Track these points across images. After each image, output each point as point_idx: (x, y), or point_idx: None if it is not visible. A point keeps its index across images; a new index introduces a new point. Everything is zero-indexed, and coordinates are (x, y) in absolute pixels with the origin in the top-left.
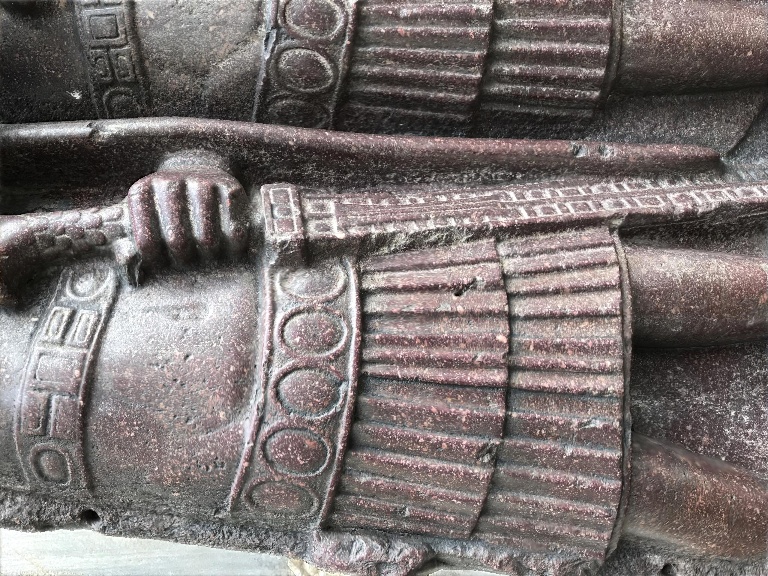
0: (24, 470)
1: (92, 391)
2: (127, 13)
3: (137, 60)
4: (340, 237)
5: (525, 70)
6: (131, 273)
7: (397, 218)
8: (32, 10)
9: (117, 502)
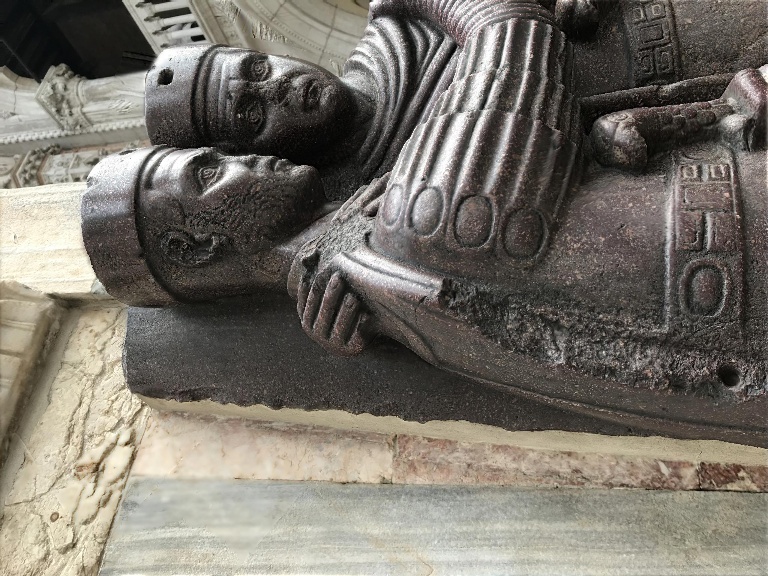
0: (668, 301)
1: (743, 210)
2: (670, 22)
3: (676, 54)
4: None
5: None
6: (745, 139)
7: None
8: (595, 32)
9: (767, 345)
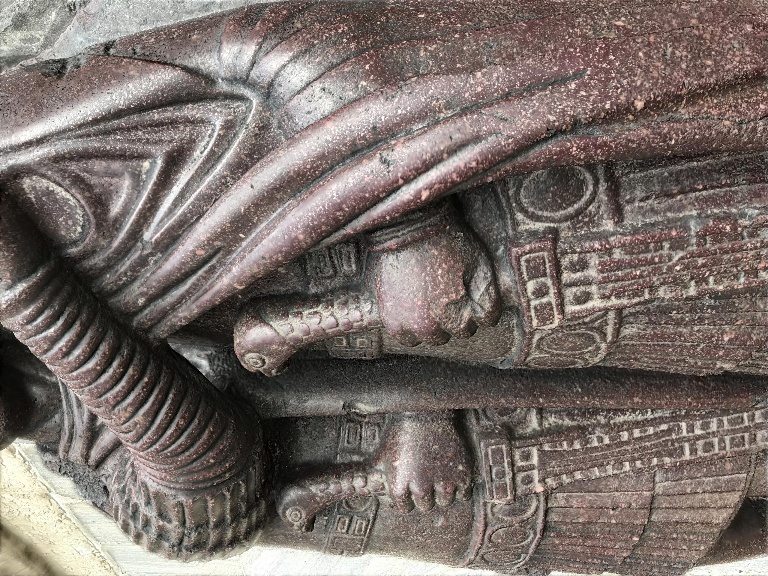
0: None
1: (367, 547)
2: (376, 351)
3: None
4: (540, 491)
5: (743, 372)
6: None
7: (585, 468)
8: None
9: None
